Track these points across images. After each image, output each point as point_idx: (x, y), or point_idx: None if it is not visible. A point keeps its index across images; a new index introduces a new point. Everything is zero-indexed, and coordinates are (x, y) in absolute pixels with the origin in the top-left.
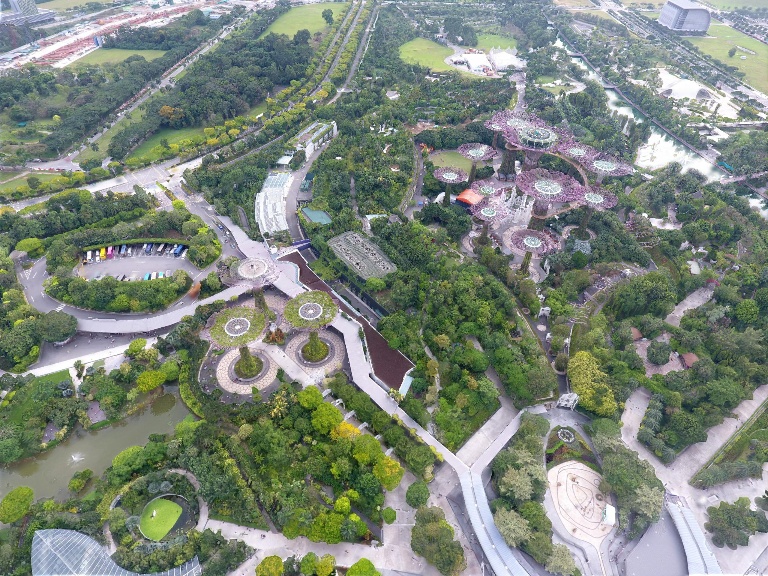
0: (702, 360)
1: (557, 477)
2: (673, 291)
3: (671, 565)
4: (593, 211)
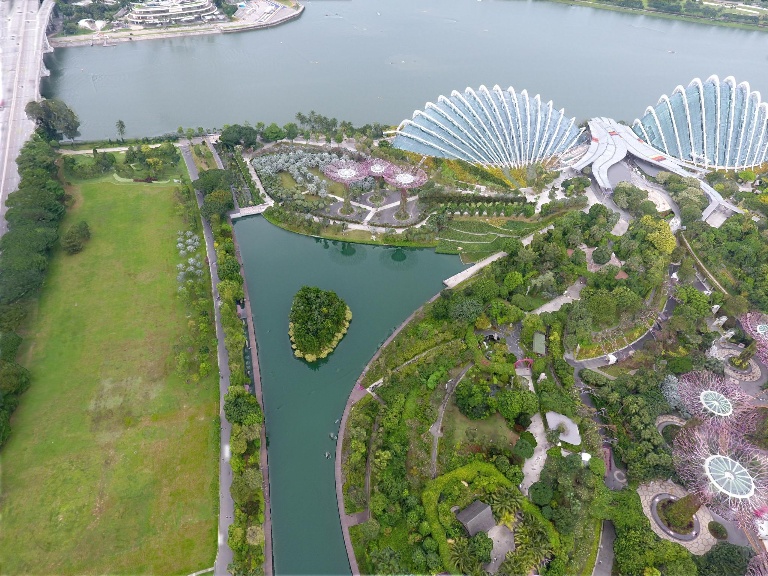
0: (578, 237)
1: (665, 206)
2: (578, 307)
3: (611, 176)
4: (667, 505)
